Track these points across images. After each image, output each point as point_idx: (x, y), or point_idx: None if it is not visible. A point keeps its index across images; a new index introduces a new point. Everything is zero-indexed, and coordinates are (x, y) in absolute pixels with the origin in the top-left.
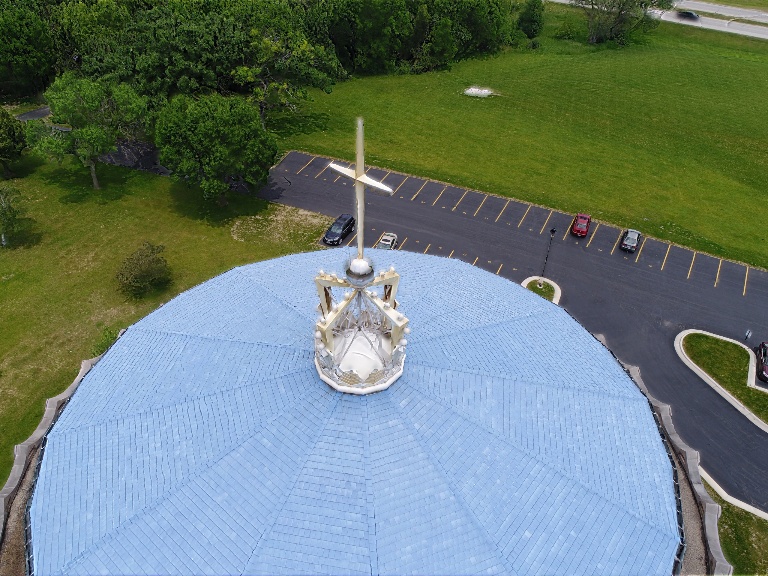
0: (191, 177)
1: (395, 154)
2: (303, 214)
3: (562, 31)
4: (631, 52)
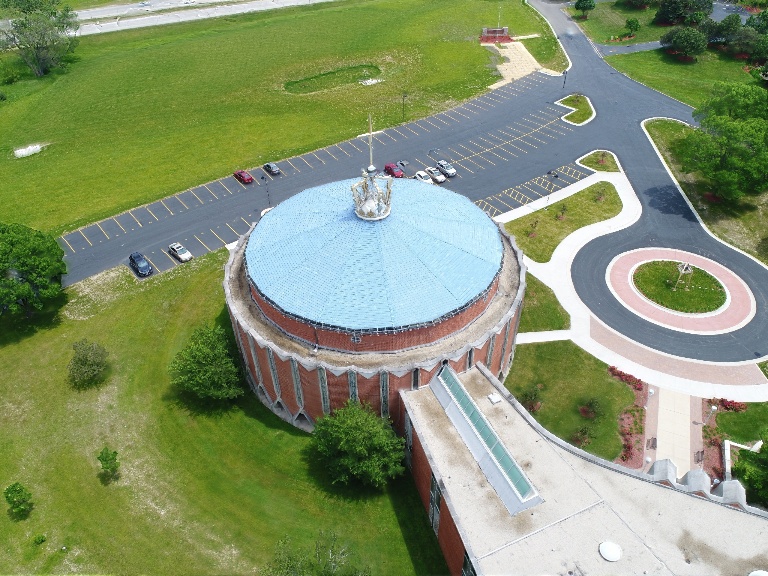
0: (32, 295)
1: (73, 215)
2: (97, 278)
3: (8, 76)
4: (81, 71)
